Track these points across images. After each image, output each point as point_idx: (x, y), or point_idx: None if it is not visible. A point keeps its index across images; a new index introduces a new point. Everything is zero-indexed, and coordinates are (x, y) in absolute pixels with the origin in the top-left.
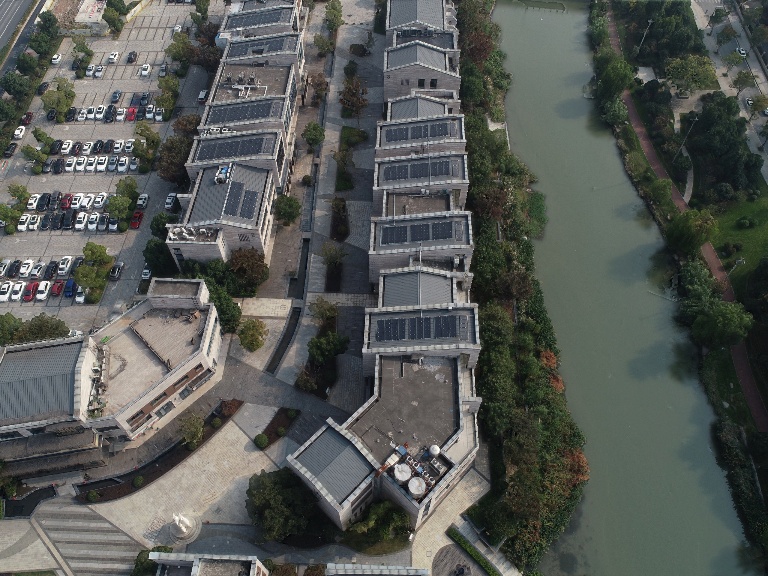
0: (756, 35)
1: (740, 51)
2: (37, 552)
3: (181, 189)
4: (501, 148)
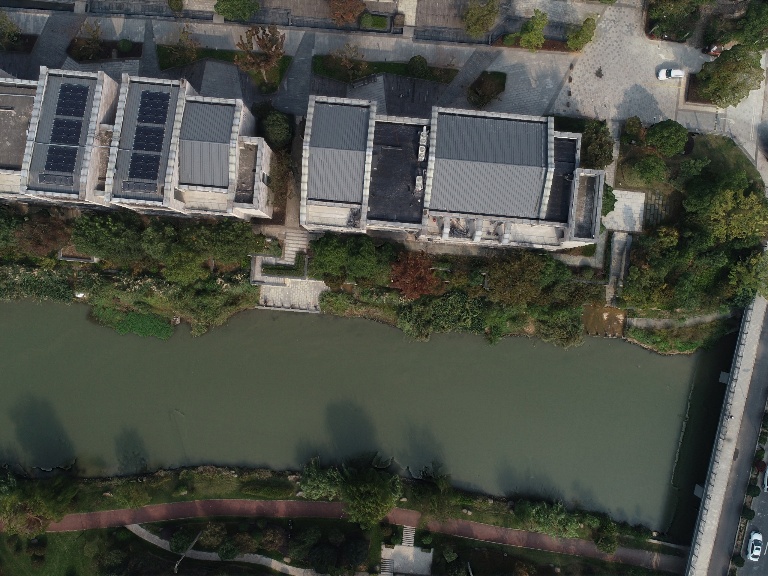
0: None
1: None
2: None
3: None
4: None
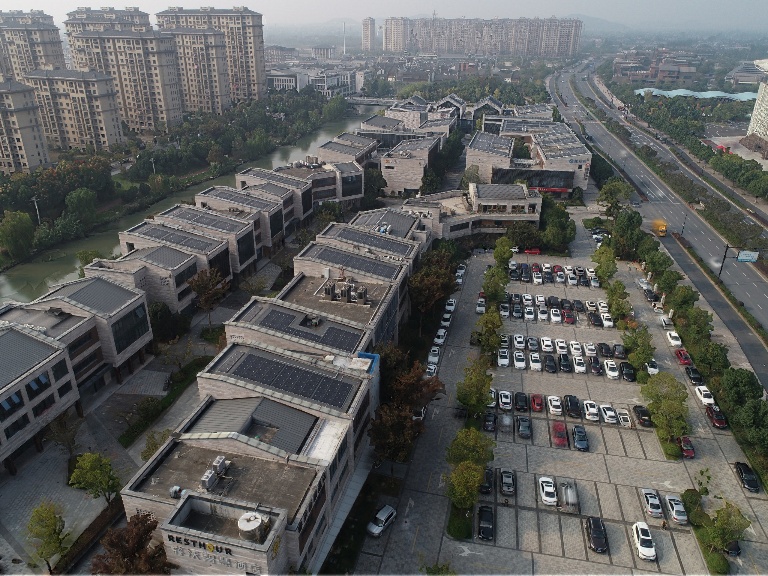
0: None
1: None
2: None
3: None
4: None
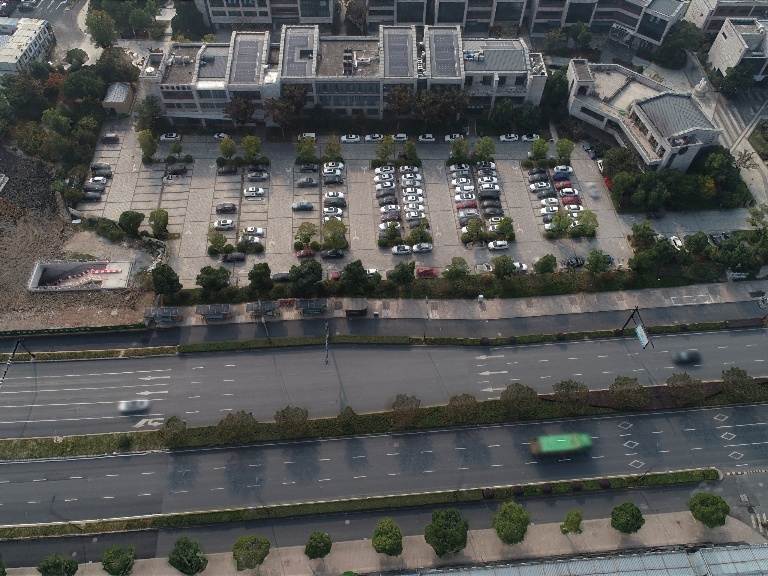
0: None
1: None
2: (743, 148)
3: (437, 136)
4: None
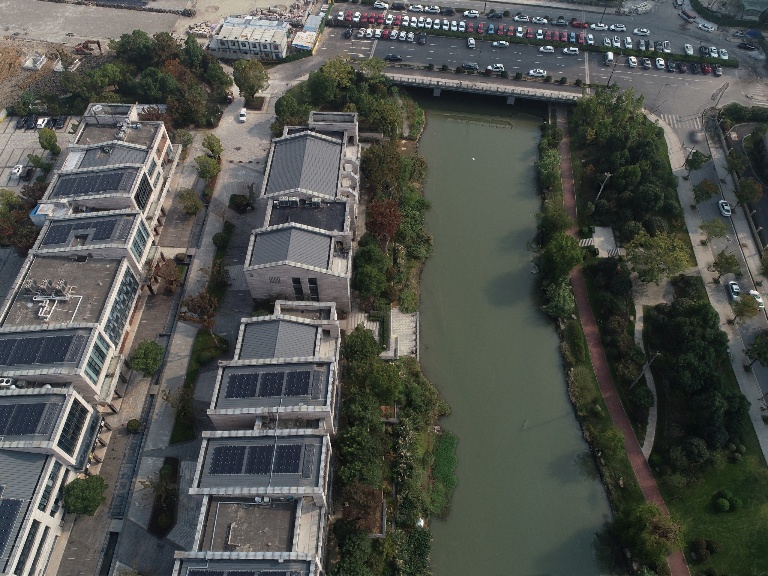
0: (743, 192)
1: (724, 207)
2: None
3: None
4: (392, 391)
